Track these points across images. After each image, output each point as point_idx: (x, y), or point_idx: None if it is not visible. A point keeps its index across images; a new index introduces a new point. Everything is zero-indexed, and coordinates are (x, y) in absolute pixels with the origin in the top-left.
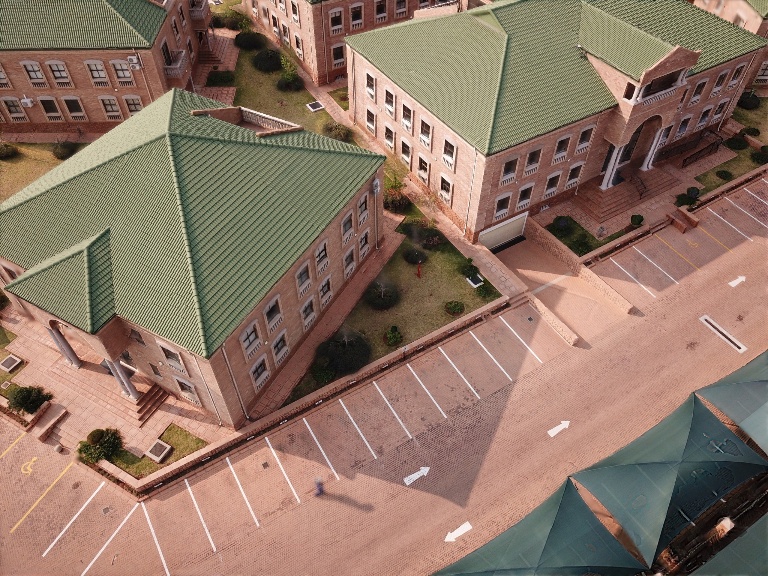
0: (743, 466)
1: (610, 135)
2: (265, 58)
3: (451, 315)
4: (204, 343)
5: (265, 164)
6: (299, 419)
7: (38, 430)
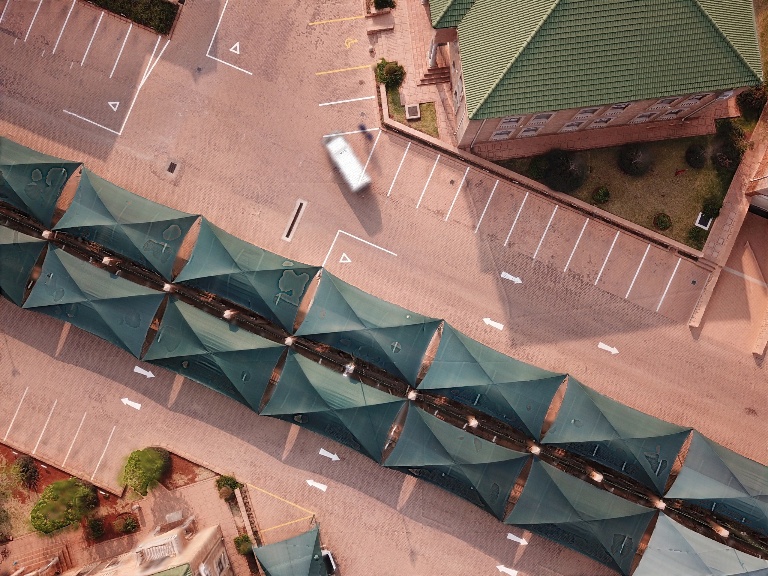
0: (647, 477)
1: None
2: None
3: (653, 223)
4: (477, 110)
5: (661, 7)
6: (495, 178)
7: (371, 23)
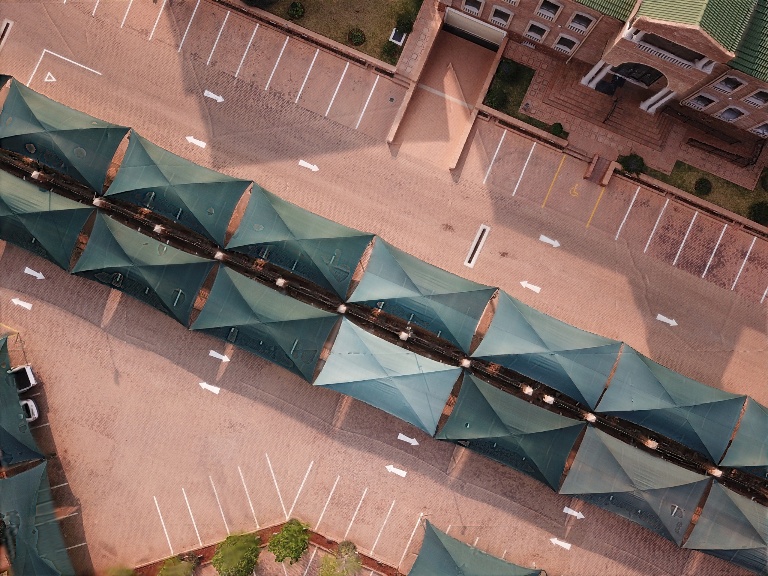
0: (324, 279)
1: (608, 43)
2: None
3: (348, 39)
4: None
5: None
6: None
7: None
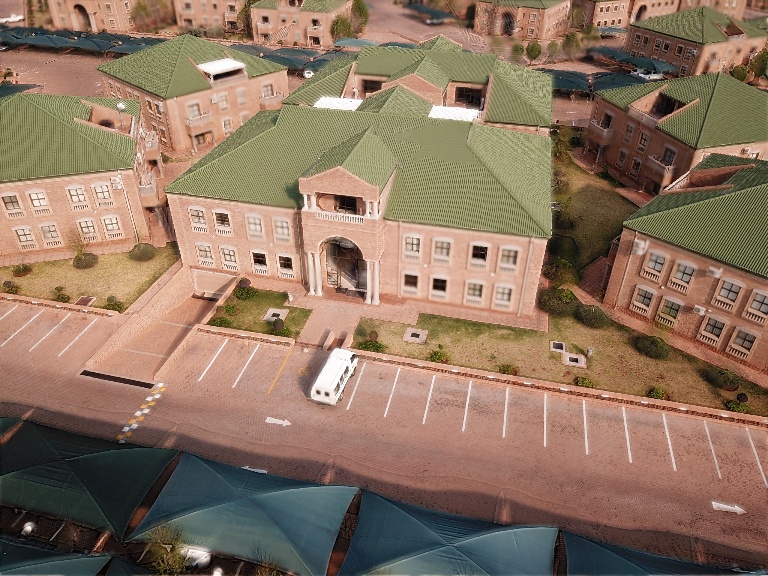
0: None
1: None
2: (568, 238)
3: None
4: None
5: None
6: None
7: None
